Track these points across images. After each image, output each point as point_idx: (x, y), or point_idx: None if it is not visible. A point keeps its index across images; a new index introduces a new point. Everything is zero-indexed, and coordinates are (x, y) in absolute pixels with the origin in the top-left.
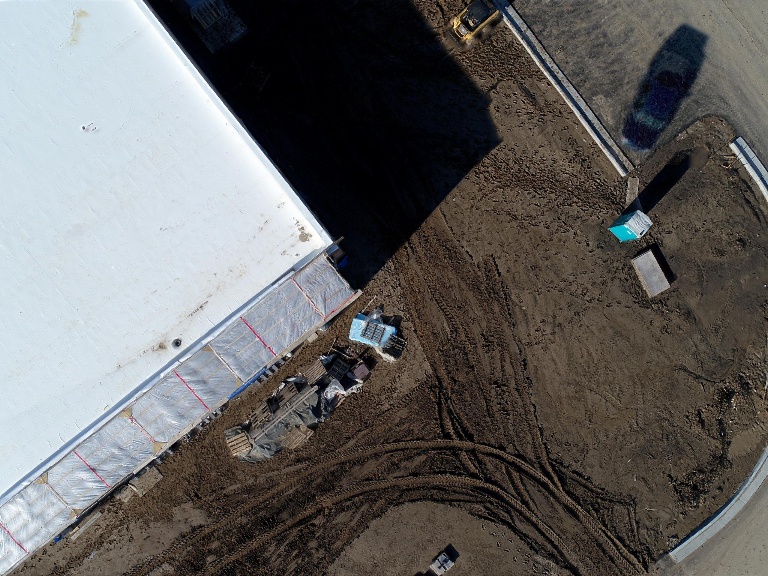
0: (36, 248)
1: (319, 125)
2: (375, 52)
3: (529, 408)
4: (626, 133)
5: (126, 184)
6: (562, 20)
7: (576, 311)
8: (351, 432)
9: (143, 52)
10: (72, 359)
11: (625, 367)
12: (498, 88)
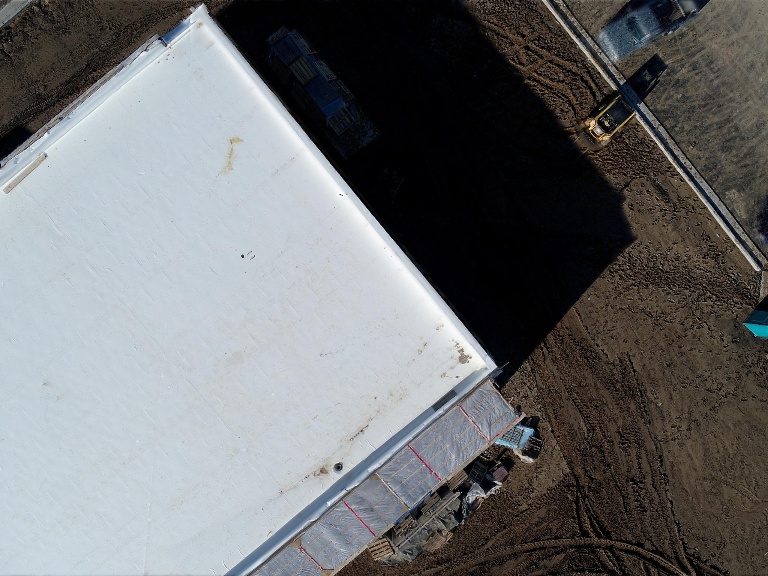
0: (197, 377)
1: (453, 228)
2: (508, 153)
3: (666, 504)
4: (759, 227)
5: (286, 311)
6: (694, 115)
7: (711, 406)
8: (489, 533)
9: (301, 179)
10: (234, 486)
11: (761, 461)
12: (632, 186)
